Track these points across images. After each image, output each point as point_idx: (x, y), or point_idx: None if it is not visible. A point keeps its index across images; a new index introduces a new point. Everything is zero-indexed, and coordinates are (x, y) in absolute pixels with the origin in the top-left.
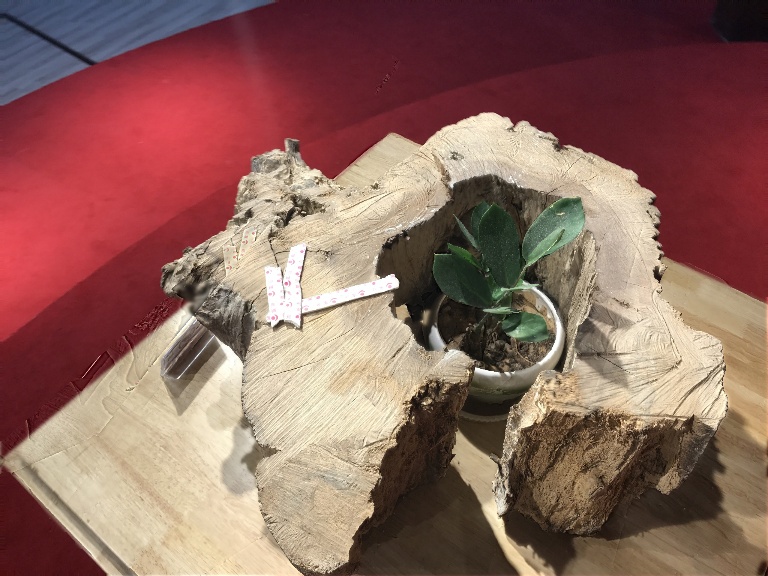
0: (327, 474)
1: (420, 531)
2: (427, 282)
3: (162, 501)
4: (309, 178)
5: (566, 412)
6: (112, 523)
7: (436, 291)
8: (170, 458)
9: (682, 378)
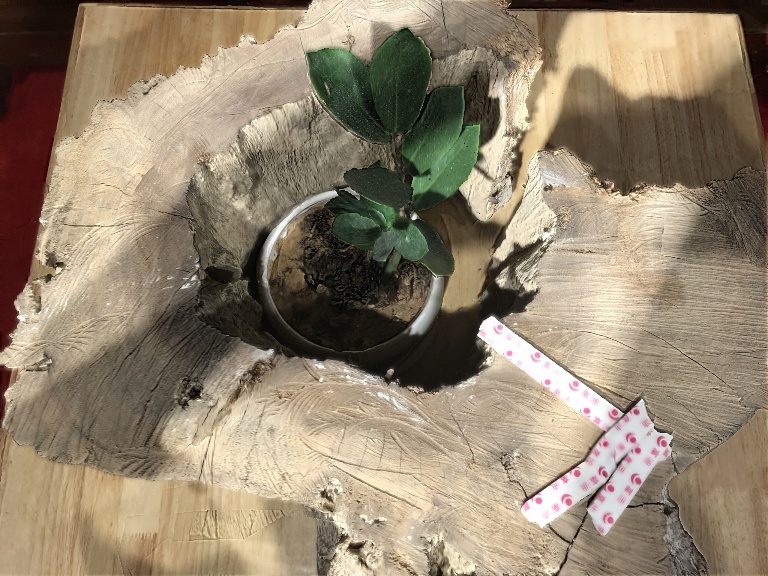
0: (760, 228)
1: None
2: None
3: (760, 532)
4: None
5: None
6: None
7: None
8: (721, 571)
9: None
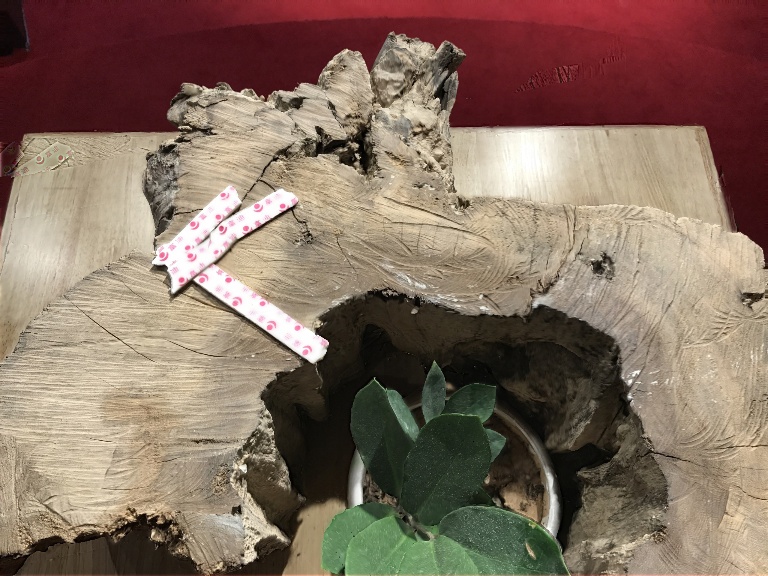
0: None
1: (192, 570)
2: (441, 364)
3: None
4: (410, 118)
5: None
6: (18, 273)
7: (463, 376)
8: None
9: None
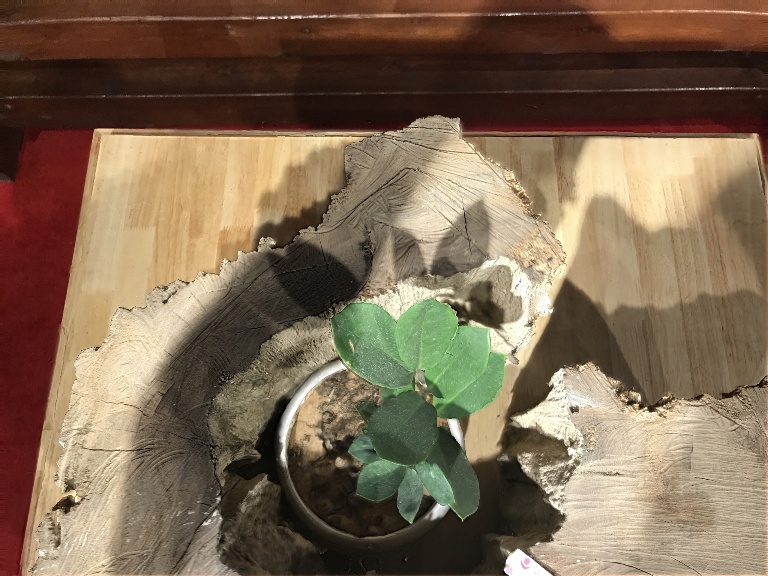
0: None
1: None
2: None
3: None
4: None
5: (557, 241)
6: None
7: (349, 569)
8: None
9: (427, 161)
